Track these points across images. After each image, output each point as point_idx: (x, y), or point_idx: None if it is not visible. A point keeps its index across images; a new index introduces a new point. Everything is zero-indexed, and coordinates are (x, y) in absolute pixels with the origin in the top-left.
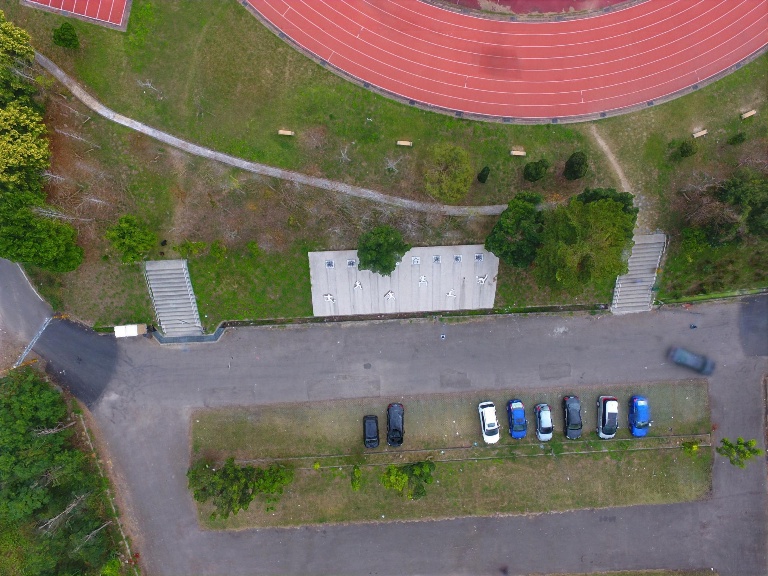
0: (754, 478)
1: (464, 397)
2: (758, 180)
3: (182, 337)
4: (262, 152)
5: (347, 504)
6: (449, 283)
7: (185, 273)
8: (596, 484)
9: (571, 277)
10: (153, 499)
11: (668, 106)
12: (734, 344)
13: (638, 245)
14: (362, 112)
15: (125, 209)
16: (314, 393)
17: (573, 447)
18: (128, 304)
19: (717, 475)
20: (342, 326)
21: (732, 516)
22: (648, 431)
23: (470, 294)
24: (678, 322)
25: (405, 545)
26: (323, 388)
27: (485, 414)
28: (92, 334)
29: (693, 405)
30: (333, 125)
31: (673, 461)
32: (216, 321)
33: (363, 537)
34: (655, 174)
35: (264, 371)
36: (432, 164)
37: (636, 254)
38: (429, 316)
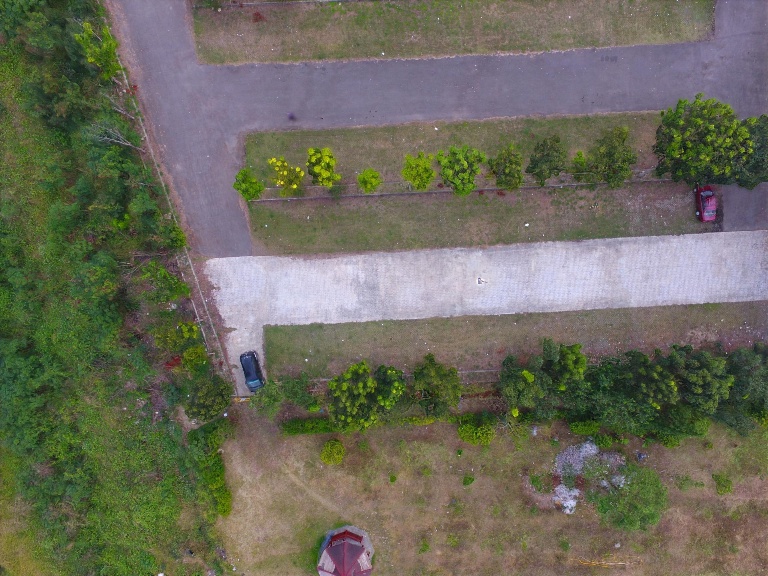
0: (757, 18)
1: None
2: None
3: None
4: None
5: (347, 40)
6: None
7: None
8: (598, 23)
9: None
10: (150, 30)
11: None
12: None
13: None
14: None
15: None
16: None
17: None
18: None
19: (720, 15)
20: None
21: (734, 56)
22: None
23: None
24: None
25: (405, 83)
26: None
27: None
28: None
29: None
30: None
31: (676, 0)
32: None
33: (363, 75)
34: None
35: None
36: None
37: None
38: None
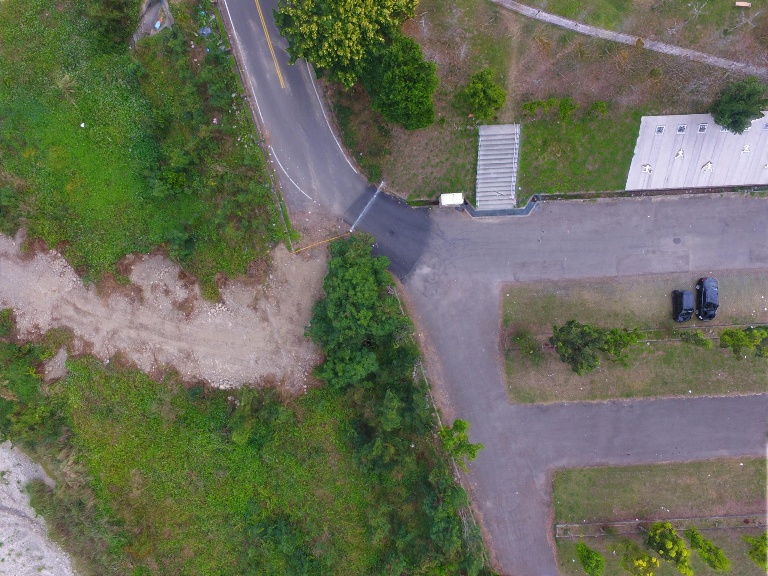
0: None
1: None
2: None
3: (493, 210)
4: (597, 14)
5: (654, 379)
6: None
7: (516, 139)
8: None
9: None
10: (463, 372)
11: None
12: None
13: None
14: None
15: (459, 73)
16: (623, 268)
17: None
18: (447, 174)
19: None
20: (652, 200)
21: None
22: None
23: None
24: None
25: (711, 420)
26: (632, 263)
27: None
28: (405, 207)
29: None
30: None
31: None
32: (528, 194)
33: (670, 412)
34: None
35: (574, 245)
36: None
37: None
38: (740, 190)
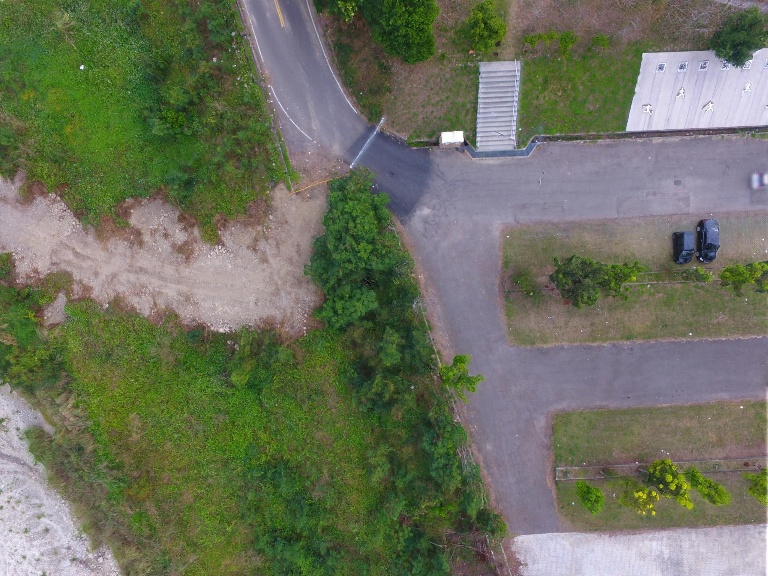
0: None
1: None
2: None
3: (494, 152)
4: None
5: (655, 321)
6: None
7: (517, 76)
8: None
9: None
10: (463, 314)
11: None
12: None
13: None
14: None
15: (459, 9)
16: (624, 210)
17: None
18: (447, 114)
19: None
20: (653, 142)
21: None
22: None
23: None
24: None
25: (712, 363)
26: (633, 205)
27: None
28: (405, 148)
29: None
30: None
31: None
32: (528, 135)
33: (670, 355)
34: None
35: (575, 187)
36: None
37: None
38: (741, 132)
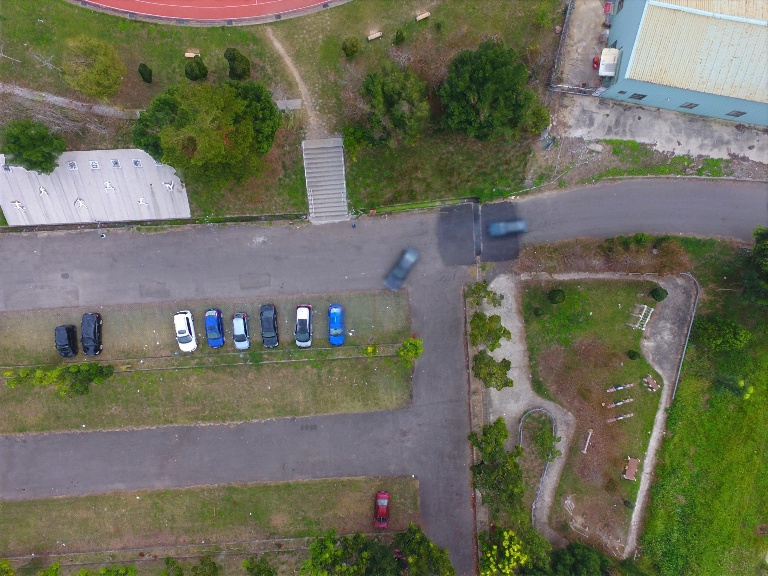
0: (454, 386)
1: (164, 307)
2: (397, 73)
3: None
4: None
5: (47, 414)
6: (137, 190)
7: None
8: (297, 393)
9: (183, 162)
10: None
11: (343, 8)
12: (433, 253)
13: (317, 149)
14: (33, 13)
15: None
16: (11, 303)
17: (273, 356)
18: None
19: (417, 383)
20: (38, 236)
21: (432, 424)
22: (349, 340)
23: (163, 202)
24: (377, 232)
25: (106, 454)
26: (20, 298)
27: (175, 321)
28: None
29: (393, 314)
30: (3, 26)
31: (374, 370)
32: None
33: (64, 446)
34: (331, 77)
35: None
36: (72, 57)
37: (318, 159)
38: (127, 226)
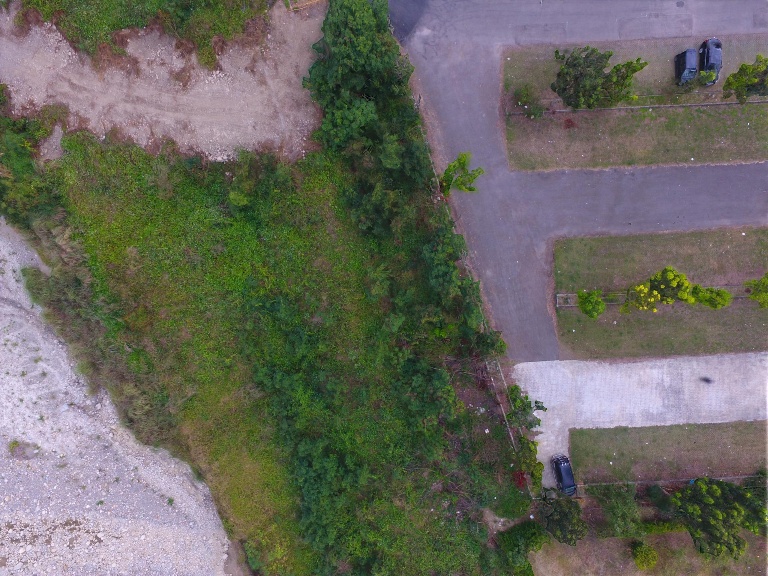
0: None
1: None
2: None
3: None
4: None
5: (656, 146)
6: None
7: None
8: None
9: None
10: (464, 138)
11: None
12: None
13: None
14: None
15: None
16: (625, 32)
17: None
18: None
19: None
20: None
21: None
22: None
23: None
24: None
25: (713, 189)
26: (635, 27)
27: None
28: None
29: None
30: None
31: None
32: None
33: (671, 180)
34: None
35: (576, 8)
36: None
37: None
38: None
